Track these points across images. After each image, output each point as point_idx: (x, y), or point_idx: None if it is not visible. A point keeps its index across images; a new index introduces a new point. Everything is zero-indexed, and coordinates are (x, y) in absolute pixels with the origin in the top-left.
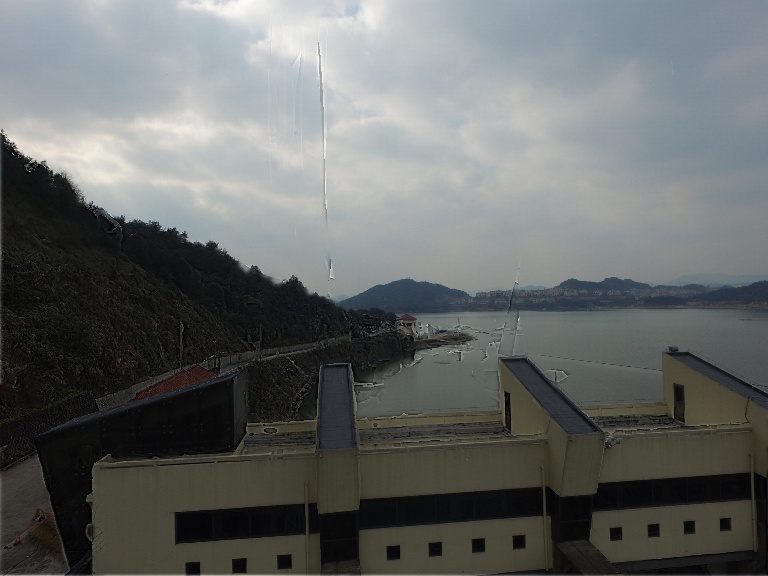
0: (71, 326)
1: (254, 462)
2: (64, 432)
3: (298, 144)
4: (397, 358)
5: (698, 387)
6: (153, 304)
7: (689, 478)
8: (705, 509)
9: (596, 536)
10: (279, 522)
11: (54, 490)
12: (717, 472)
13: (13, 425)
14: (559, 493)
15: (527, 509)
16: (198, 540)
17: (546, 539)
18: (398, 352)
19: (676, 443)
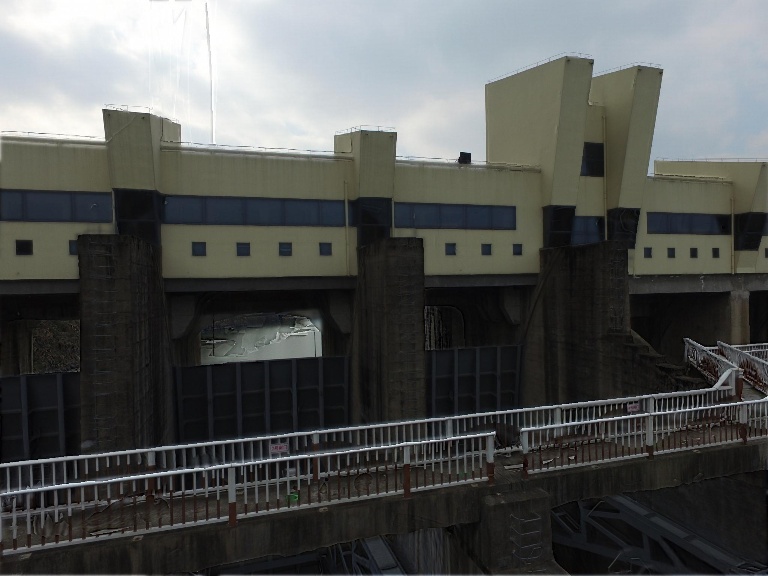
0: None
1: None
2: None
3: (185, 108)
4: (272, 326)
5: None
6: None
7: (27, 191)
8: (49, 228)
9: None
10: None
11: None
12: (68, 188)
13: None
14: None
15: None
16: None
17: None
18: (274, 320)
19: (7, 148)
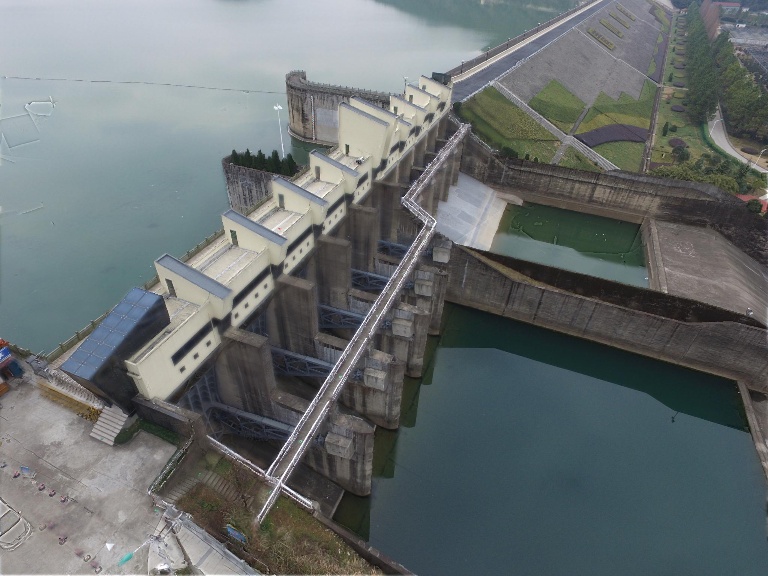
0: None
1: None
2: None
3: None
4: None
5: (290, 195)
6: None
7: None
8: None
9: None
10: (202, 333)
11: (106, 392)
12: (305, 229)
13: None
14: None
15: (266, 275)
16: (181, 360)
17: (272, 280)
18: None
19: None
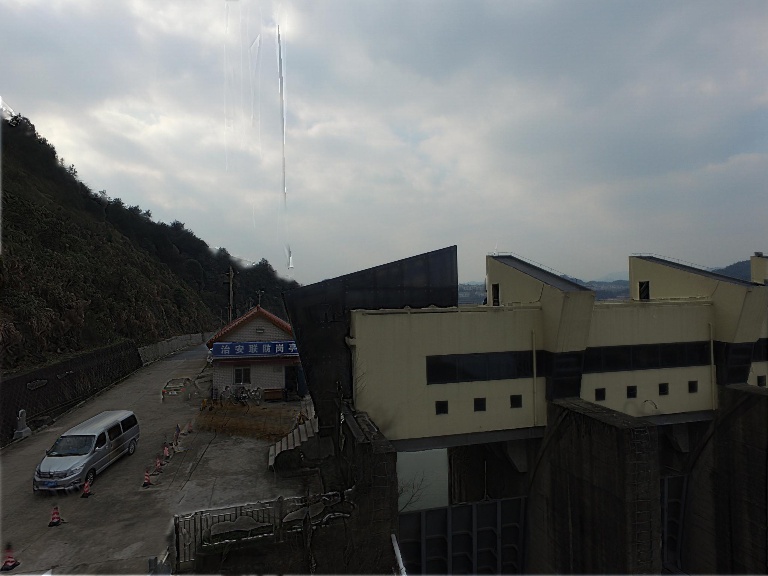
0: (103, 275)
1: (490, 313)
2: (309, 289)
3: (256, 129)
4: None
5: None
6: (149, 271)
7: None
8: None
9: (748, 382)
10: (508, 368)
11: (301, 343)
12: None
13: (90, 357)
14: (732, 340)
15: (697, 360)
16: (445, 382)
17: (713, 384)
18: None
19: None
